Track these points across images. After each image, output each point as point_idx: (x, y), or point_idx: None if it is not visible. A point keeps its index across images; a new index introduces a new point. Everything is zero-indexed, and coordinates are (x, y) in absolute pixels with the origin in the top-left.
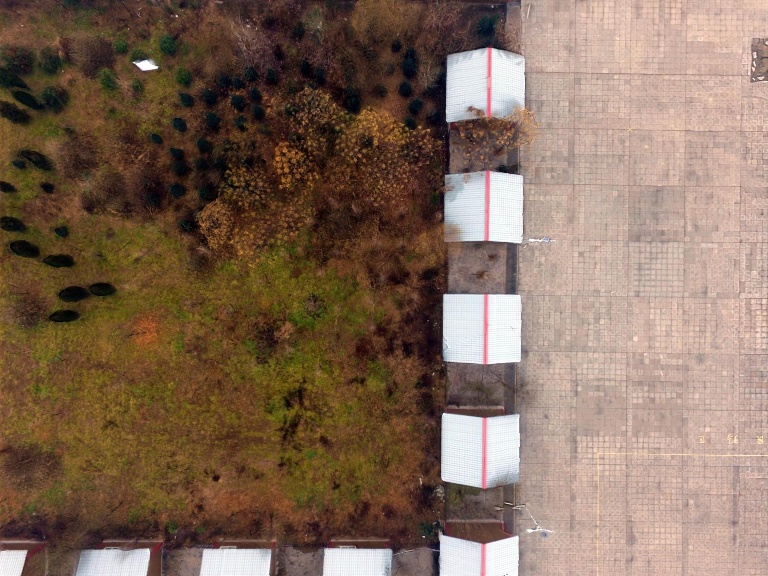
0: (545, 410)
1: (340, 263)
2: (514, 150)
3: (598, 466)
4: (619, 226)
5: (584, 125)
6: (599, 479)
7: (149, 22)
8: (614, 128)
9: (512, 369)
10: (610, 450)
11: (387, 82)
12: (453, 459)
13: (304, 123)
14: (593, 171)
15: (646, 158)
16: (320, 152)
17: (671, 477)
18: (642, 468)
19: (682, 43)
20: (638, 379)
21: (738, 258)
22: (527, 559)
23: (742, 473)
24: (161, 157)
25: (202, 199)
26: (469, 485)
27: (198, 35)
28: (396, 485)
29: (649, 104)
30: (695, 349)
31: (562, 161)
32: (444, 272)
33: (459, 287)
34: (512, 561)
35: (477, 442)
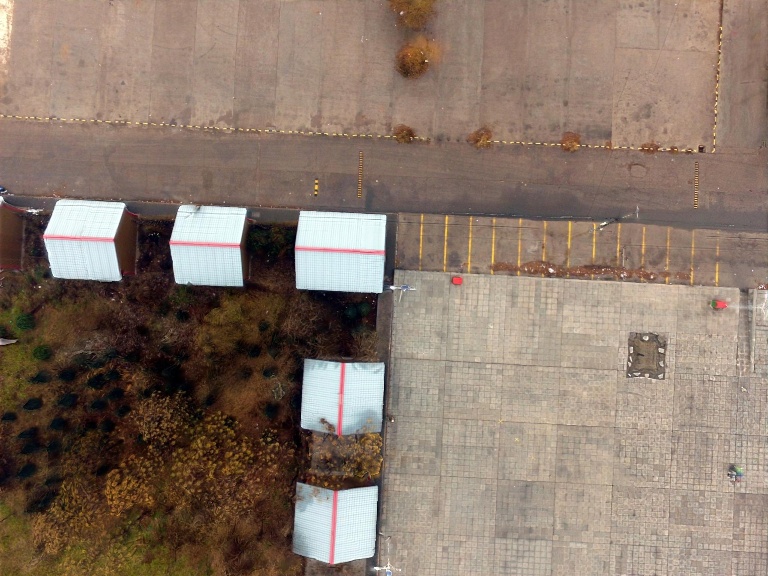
0: None
1: (194, 550)
2: None
3: None
4: (486, 521)
5: (453, 415)
6: None
7: (11, 292)
8: (484, 419)
9: None
10: None
11: (253, 361)
12: None
13: (146, 436)
14: (461, 463)
15: (516, 451)
16: (158, 474)
17: None
18: None
19: (557, 334)
20: None
21: (608, 560)
22: None
23: None
24: (15, 432)
25: (49, 489)
26: None
27: (61, 307)
28: None
29: (521, 395)
30: None
31: (429, 451)
32: (302, 562)
33: None
34: None
35: None
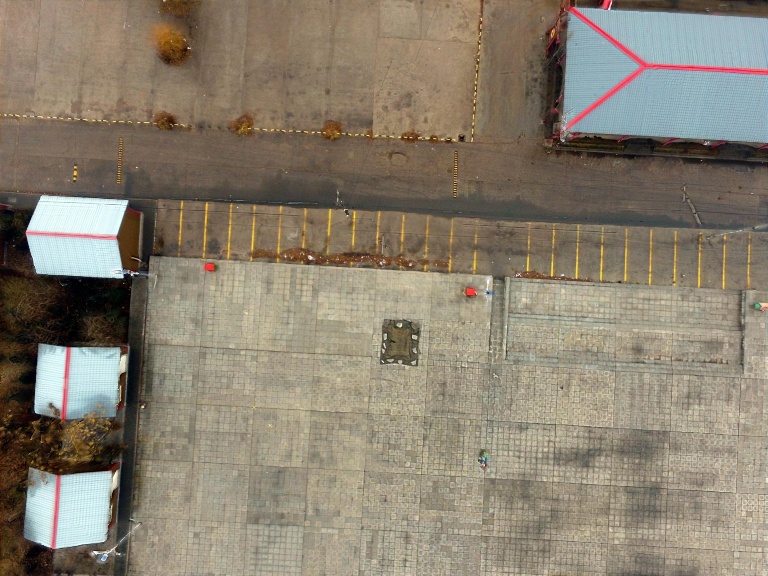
0: None
1: None
2: (132, 425)
3: None
4: (238, 507)
5: (207, 401)
6: None
7: None
8: (238, 405)
9: None
10: None
11: None
12: None
13: None
14: (214, 449)
15: (269, 437)
16: None
17: None
18: None
19: (312, 321)
20: None
21: (359, 545)
22: None
23: None
24: None
25: None
26: None
27: None
28: None
29: (275, 382)
30: None
31: (182, 437)
32: None
33: (65, 566)
34: None
35: None
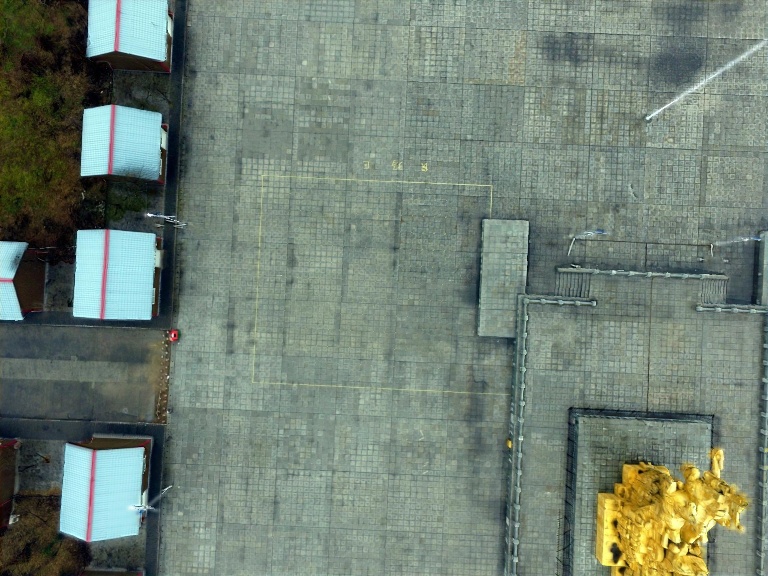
0: (211, 131)
1: None
2: None
3: (262, 188)
4: None
5: None
6: (262, 201)
7: None
8: None
9: (178, 88)
10: (275, 173)
11: None
12: (89, 152)
13: None
14: None
15: None
16: None
17: (334, 201)
18: (306, 192)
19: None
20: (305, 103)
21: None
22: (188, 278)
23: (405, 200)
24: None
25: None
26: (99, 174)
27: None
28: (58, 199)
29: None
30: (363, 75)
31: None
32: None
33: None
34: (146, 257)
35: (106, 130)
